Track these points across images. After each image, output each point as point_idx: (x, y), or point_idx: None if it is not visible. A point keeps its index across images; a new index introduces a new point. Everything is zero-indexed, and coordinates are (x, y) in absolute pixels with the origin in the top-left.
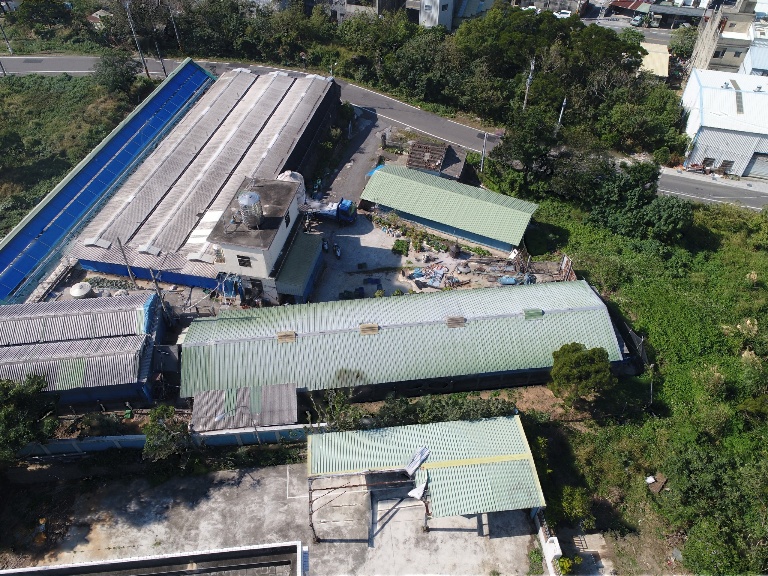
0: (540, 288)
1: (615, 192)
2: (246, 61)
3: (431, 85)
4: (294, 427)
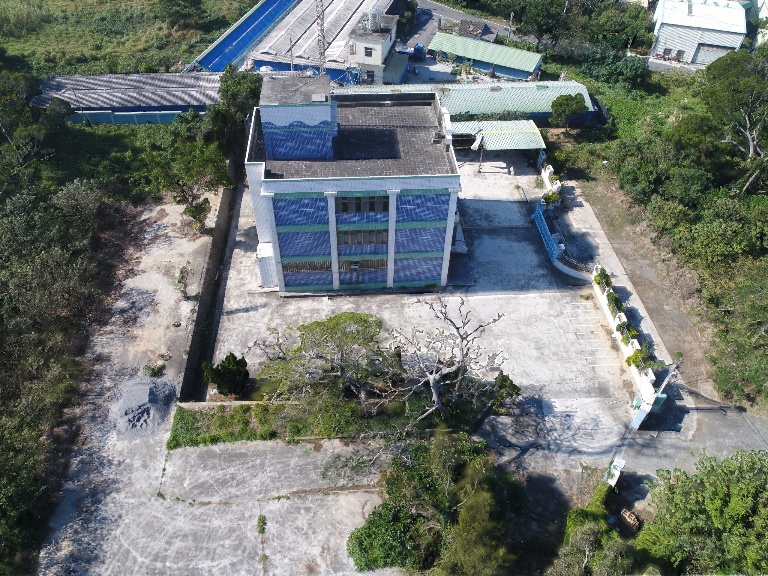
0: (546, 82)
1: (598, 52)
2: None
3: None
4: None
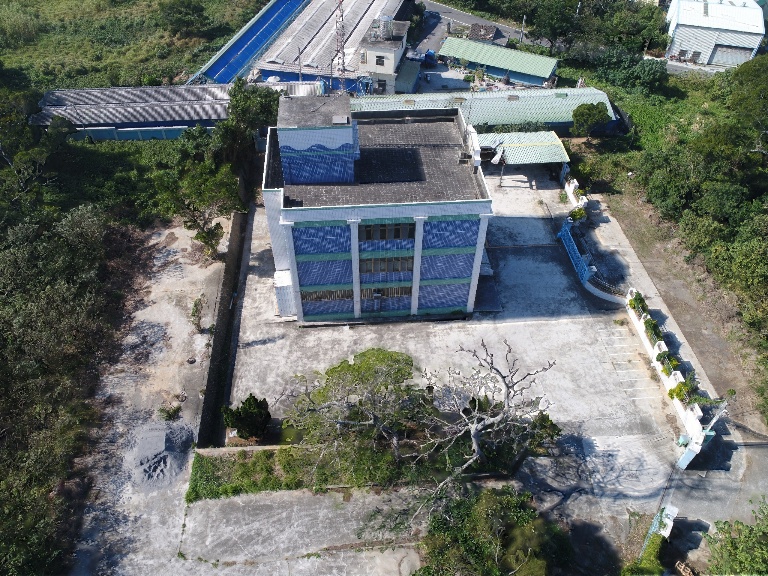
0: (564, 89)
1: (614, 56)
2: None
3: None
4: None
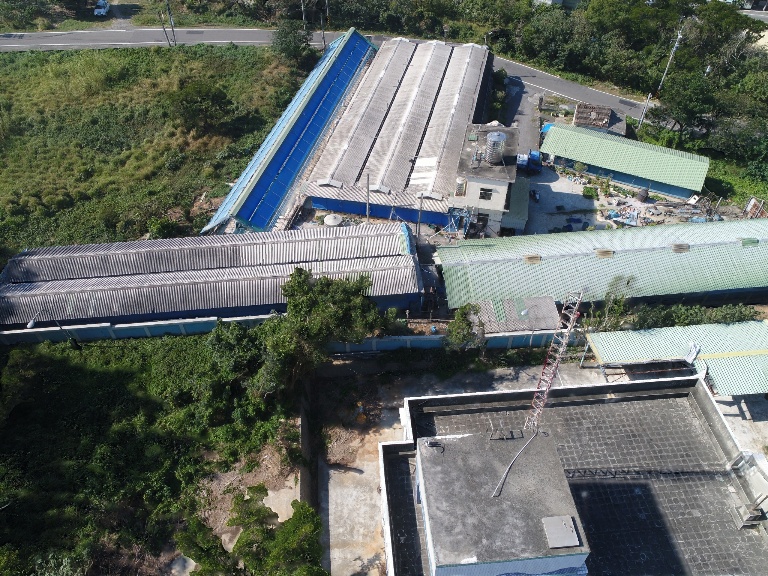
0: (742, 223)
1: None
2: (389, 34)
3: (572, 55)
4: None
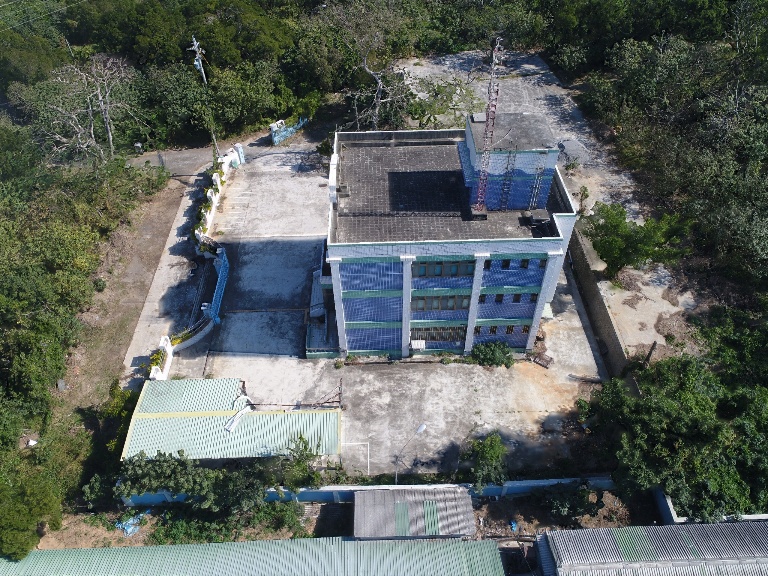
0: None
1: None
2: None
3: None
4: (358, 487)
